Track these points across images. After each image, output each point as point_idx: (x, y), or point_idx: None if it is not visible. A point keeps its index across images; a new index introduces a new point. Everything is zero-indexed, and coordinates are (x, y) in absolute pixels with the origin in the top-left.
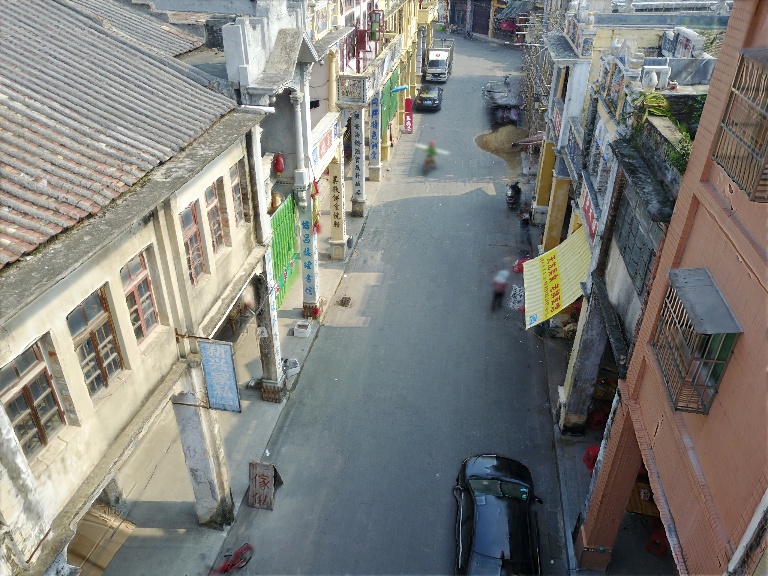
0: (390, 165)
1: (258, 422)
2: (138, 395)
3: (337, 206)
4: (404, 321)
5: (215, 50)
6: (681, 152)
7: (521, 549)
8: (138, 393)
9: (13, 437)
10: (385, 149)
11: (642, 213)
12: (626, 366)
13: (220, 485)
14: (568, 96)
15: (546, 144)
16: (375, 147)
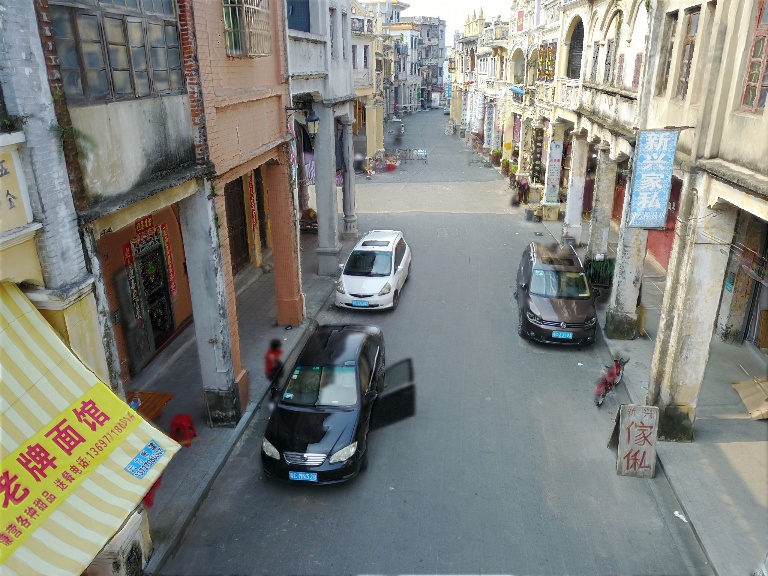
0: None
1: (747, 558)
2: None
3: None
4: None
5: None
6: None
7: (320, 334)
8: None
9: None
10: None
11: (116, 0)
12: (206, 160)
13: None
14: None
15: None
16: None
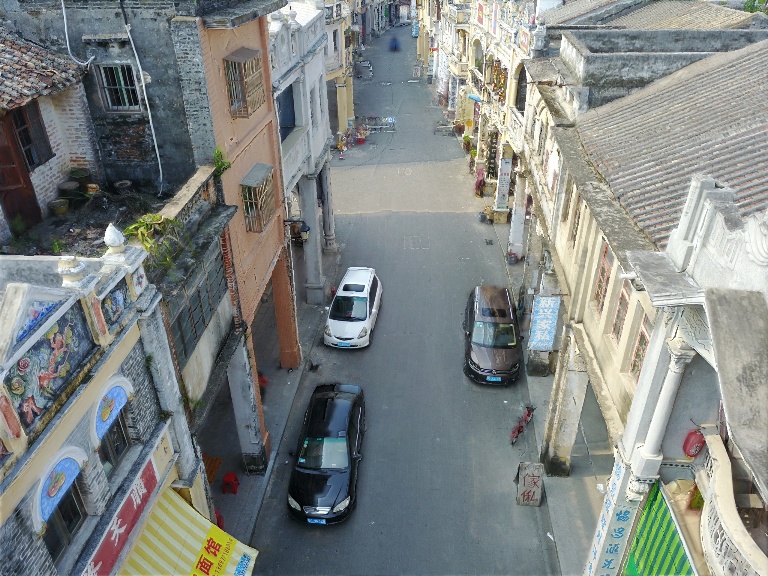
0: None
1: (582, 567)
2: None
3: None
4: None
5: None
6: (221, 162)
7: (319, 404)
8: None
9: (558, 189)
10: None
11: None
12: (241, 323)
13: None
14: None
15: None
16: None
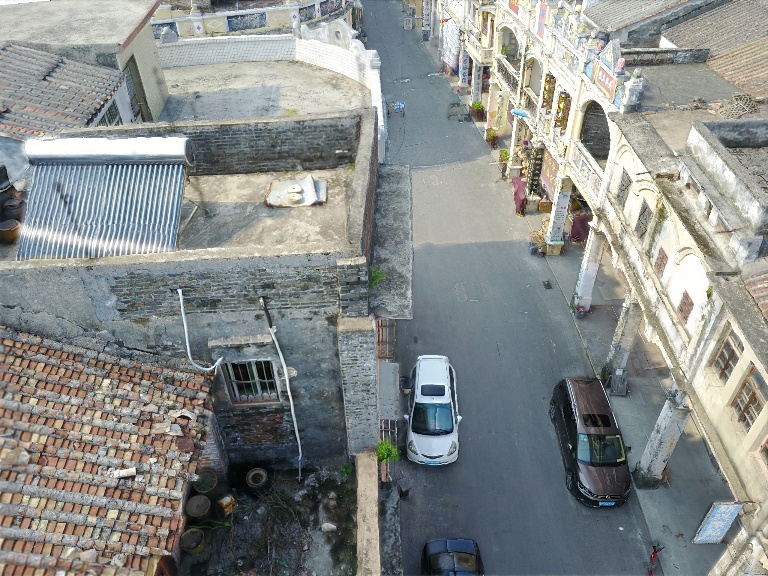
0: None
1: None
2: None
3: None
4: None
5: None
6: (386, 453)
7: None
8: None
9: (707, 336)
10: None
11: None
12: None
13: None
14: None
15: None
16: None
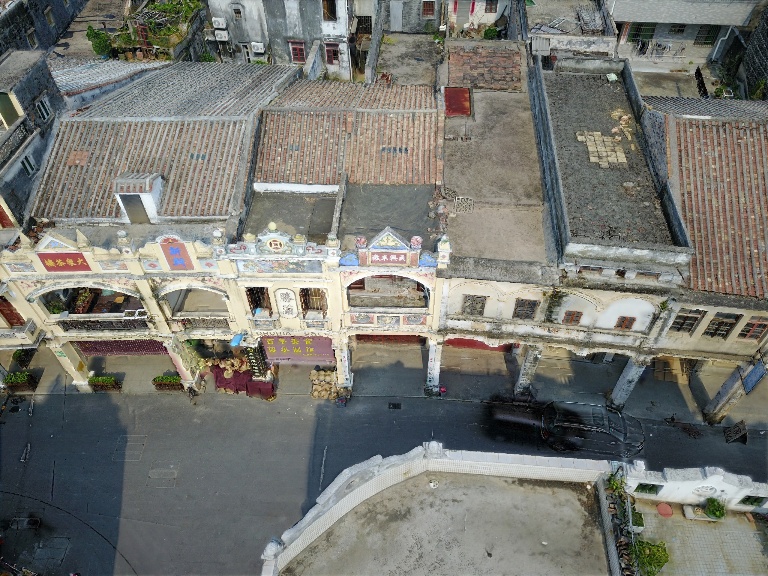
0: None
1: None
2: (720, 349)
3: None
4: None
5: None
6: None
7: None
8: (720, 349)
9: None
10: None
11: None
12: None
13: (720, 408)
14: None
15: None
16: None
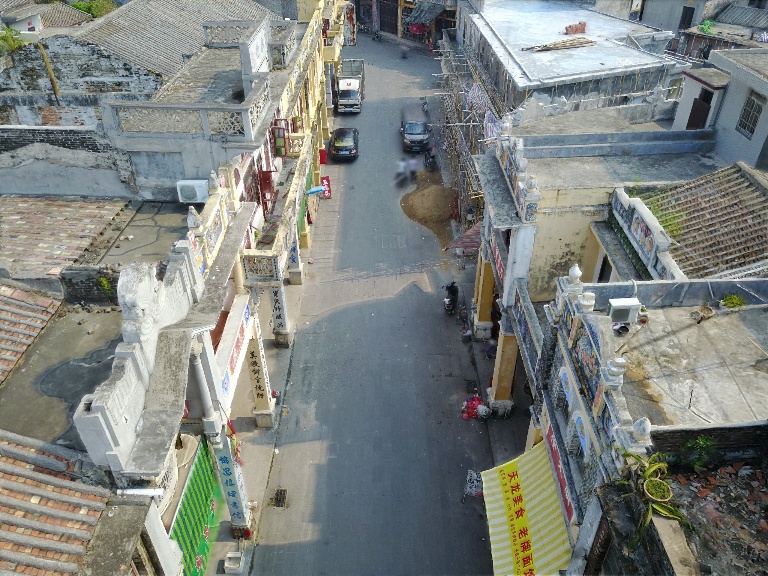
0: (311, 253)
1: None
2: None
3: (258, 379)
4: (351, 524)
5: (78, 310)
6: None
7: None
8: None
9: None
10: (304, 236)
11: None
12: None
13: None
14: (512, 258)
15: (484, 264)
16: (293, 251)
